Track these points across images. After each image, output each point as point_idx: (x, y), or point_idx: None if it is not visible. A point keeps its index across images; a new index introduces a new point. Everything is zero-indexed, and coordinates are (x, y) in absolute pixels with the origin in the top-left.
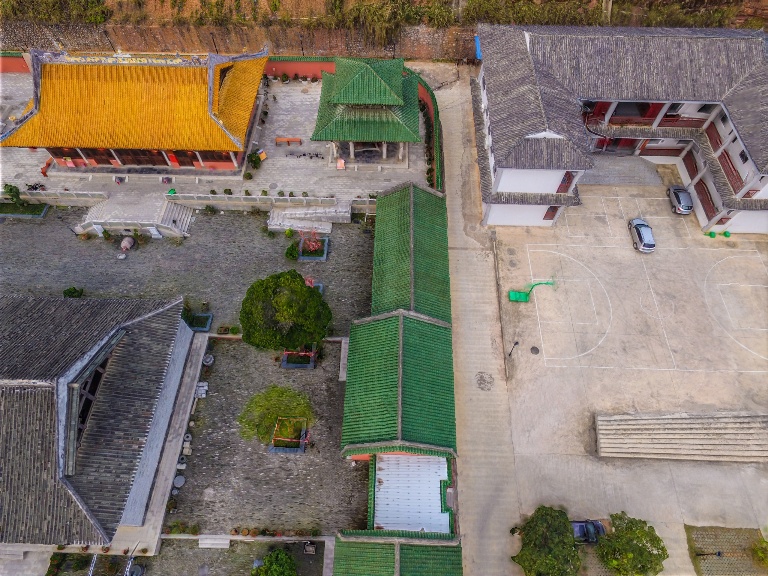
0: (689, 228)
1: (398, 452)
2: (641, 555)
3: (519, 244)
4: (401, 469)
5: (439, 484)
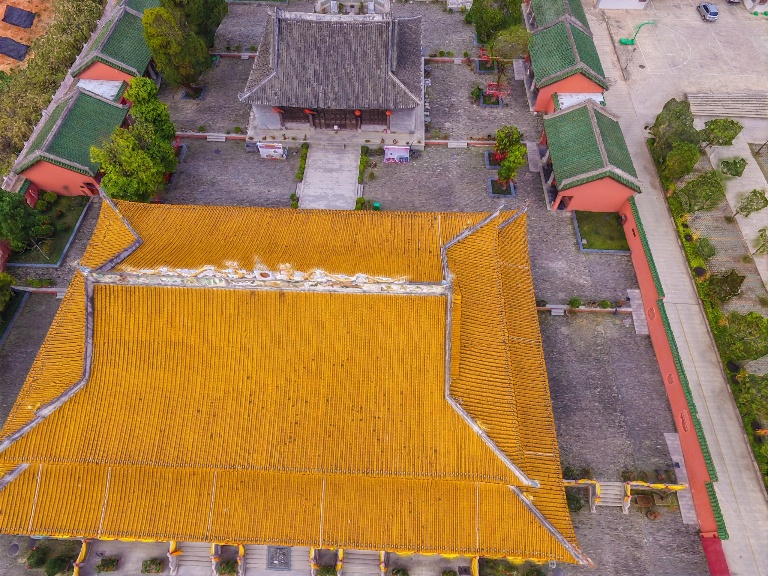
0: (740, 10)
1: (573, 85)
2: (727, 126)
3: (622, 18)
4: (574, 98)
5: (599, 103)
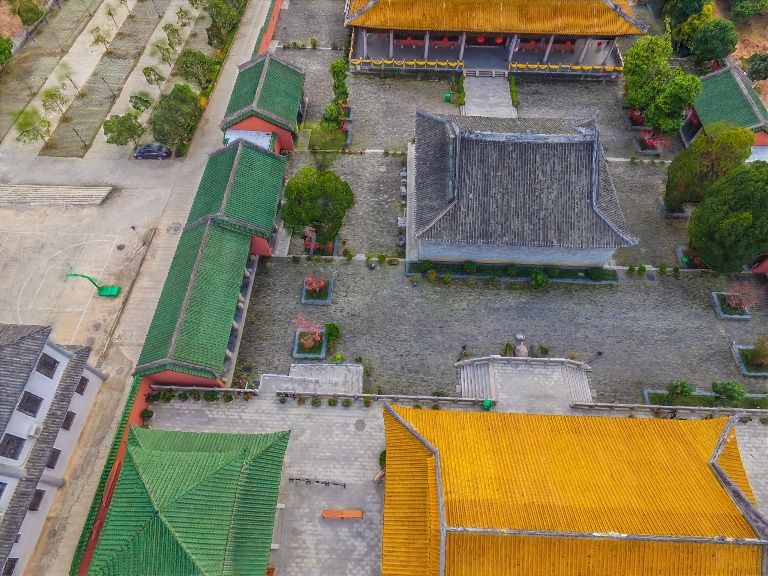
0: None
1: None
2: None
3: None
4: None
5: None
